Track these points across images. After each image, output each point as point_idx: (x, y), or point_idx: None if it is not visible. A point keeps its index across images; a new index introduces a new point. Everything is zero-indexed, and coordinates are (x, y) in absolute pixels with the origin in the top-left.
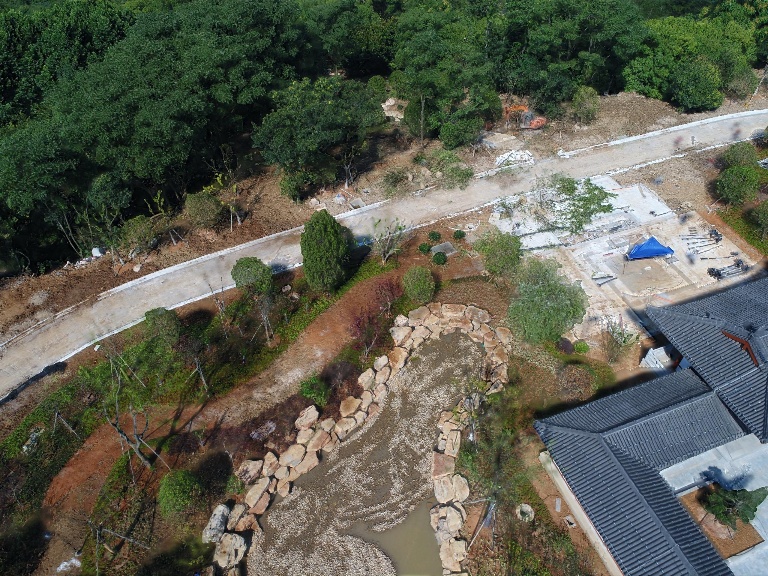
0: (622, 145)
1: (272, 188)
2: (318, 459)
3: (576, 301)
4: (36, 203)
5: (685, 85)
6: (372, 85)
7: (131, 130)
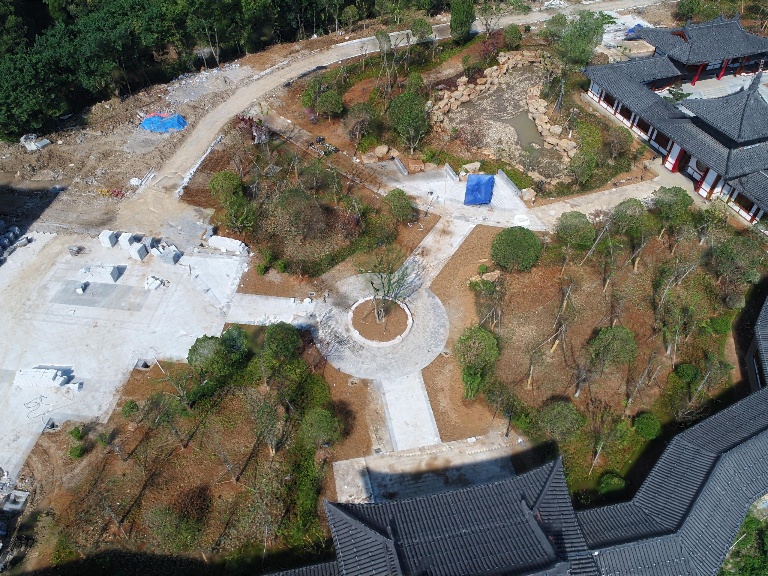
0: None
1: None
2: None
3: (599, 27)
4: (285, 5)
5: None
6: None
7: None
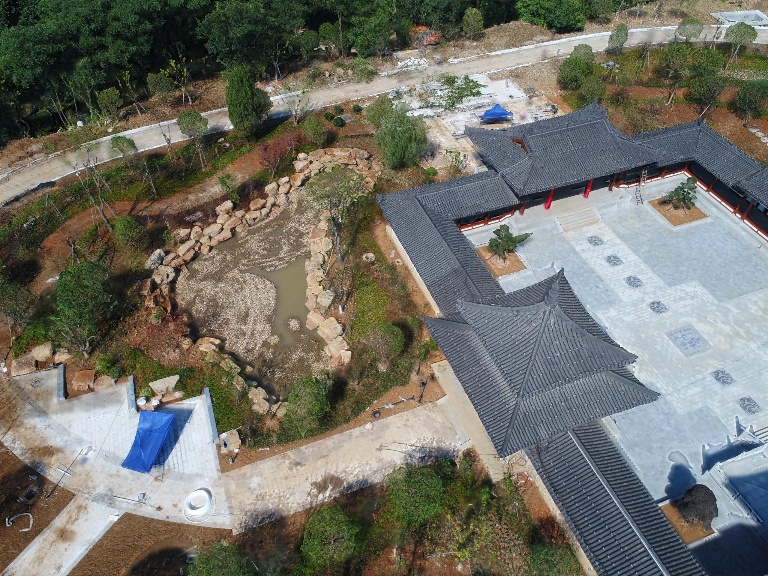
0: (501, 55)
1: (219, 84)
2: (232, 235)
3: (417, 127)
4: (34, 84)
5: (553, 8)
6: (322, 31)
7: (105, 24)
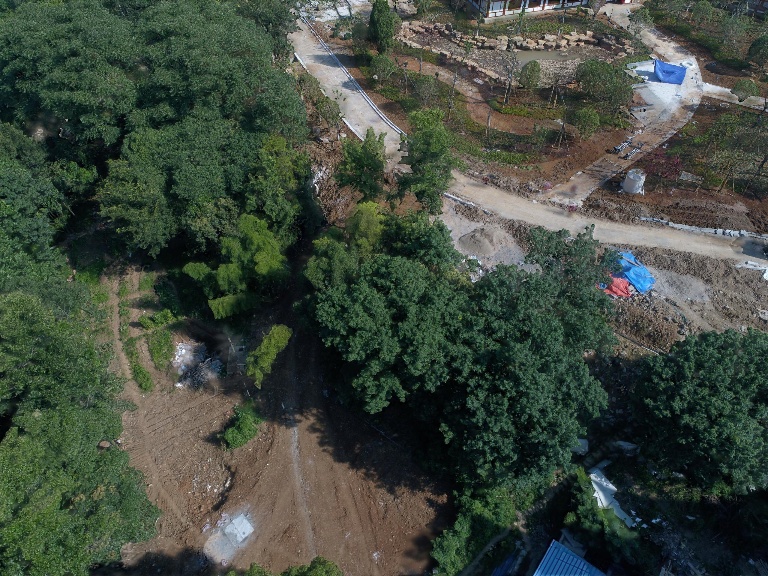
0: None
1: None
2: None
3: None
4: None
5: None
6: None
7: None
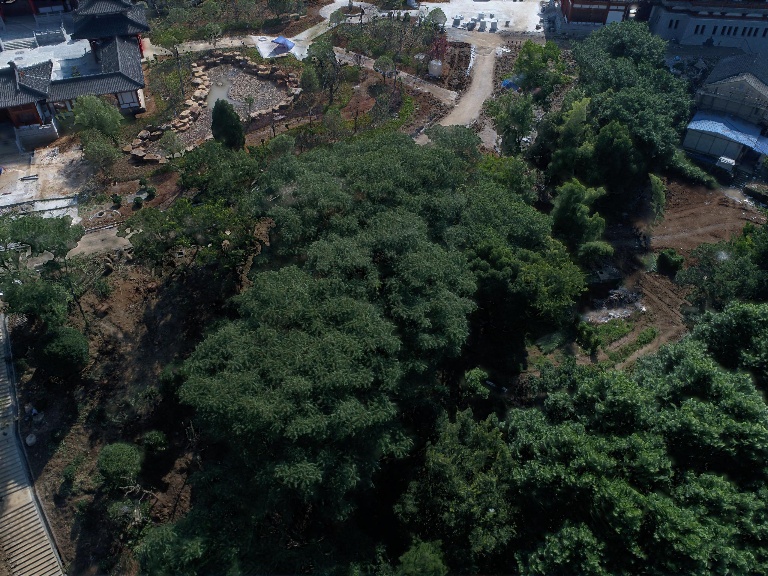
0: None
1: None
2: None
3: None
4: None
5: None
6: None
7: None
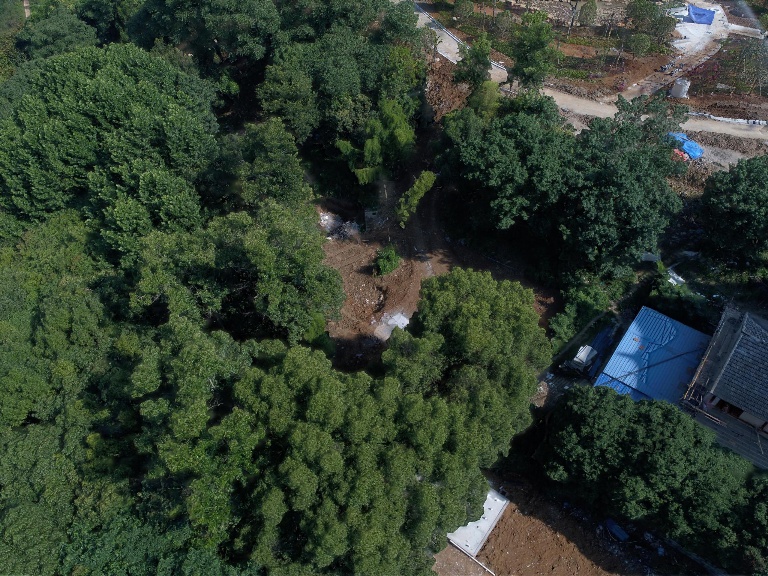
0: None
1: None
2: None
3: None
4: None
5: None
6: None
7: None
